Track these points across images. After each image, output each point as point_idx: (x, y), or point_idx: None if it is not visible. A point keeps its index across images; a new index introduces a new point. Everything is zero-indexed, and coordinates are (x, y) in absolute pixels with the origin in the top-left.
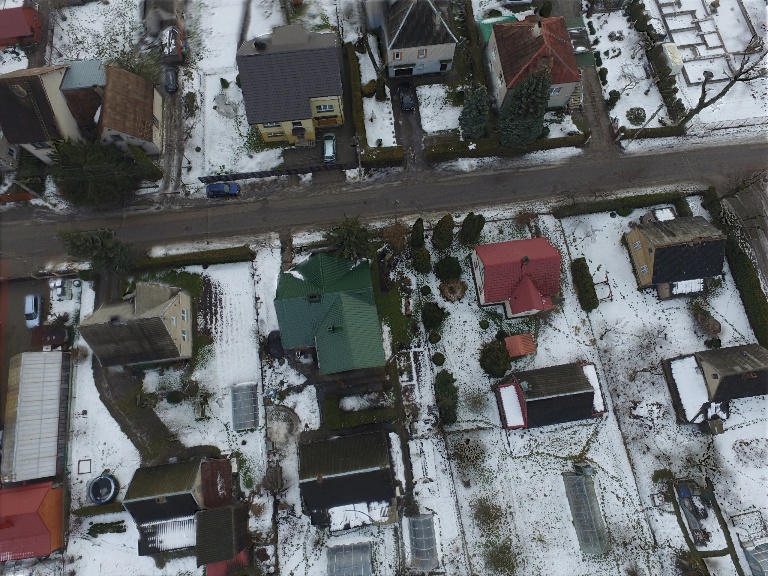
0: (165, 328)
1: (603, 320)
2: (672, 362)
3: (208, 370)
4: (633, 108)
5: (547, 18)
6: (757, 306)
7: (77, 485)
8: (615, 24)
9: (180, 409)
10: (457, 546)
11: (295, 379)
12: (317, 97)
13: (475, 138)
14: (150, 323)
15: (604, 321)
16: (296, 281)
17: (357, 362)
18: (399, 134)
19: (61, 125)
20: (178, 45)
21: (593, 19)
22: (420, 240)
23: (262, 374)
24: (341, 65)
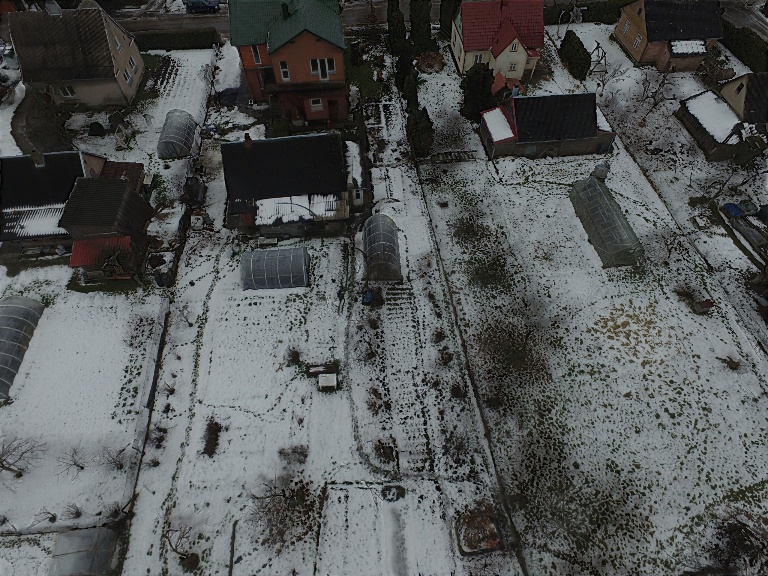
0: (104, 29)
1: None
2: (686, 102)
3: None
4: None
5: None
6: None
7: None
8: None
9: (100, 141)
10: None
11: (243, 120)
12: None
13: None
14: (88, 19)
15: None
16: None
17: (311, 26)
18: None
19: None
20: None
21: None
22: None
23: (206, 117)
24: None
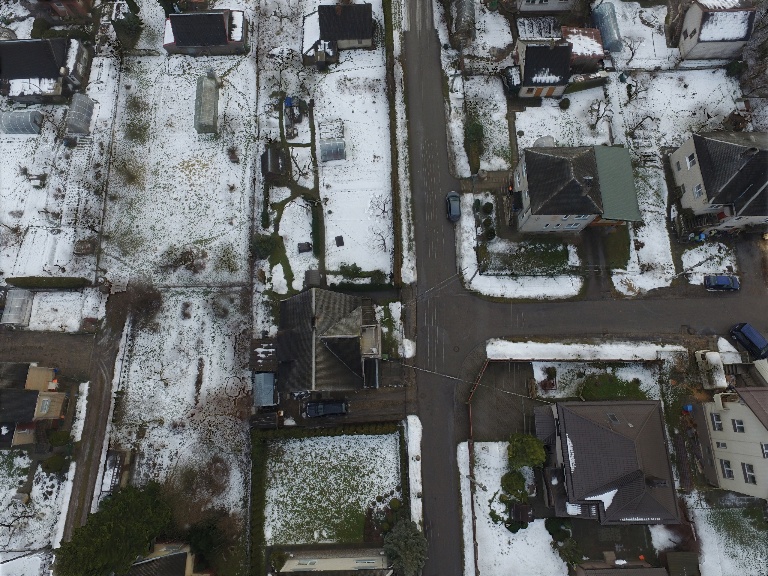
0: None
1: None
2: (305, 18)
3: None
4: None
5: None
6: None
7: None
8: None
9: None
10: (107, 123)
11: (21, 12)
12: None
13: None
14: None
15: None
16: None
17: None
18: None
19: None
20: None
21: None
22: None
23: None
24: None
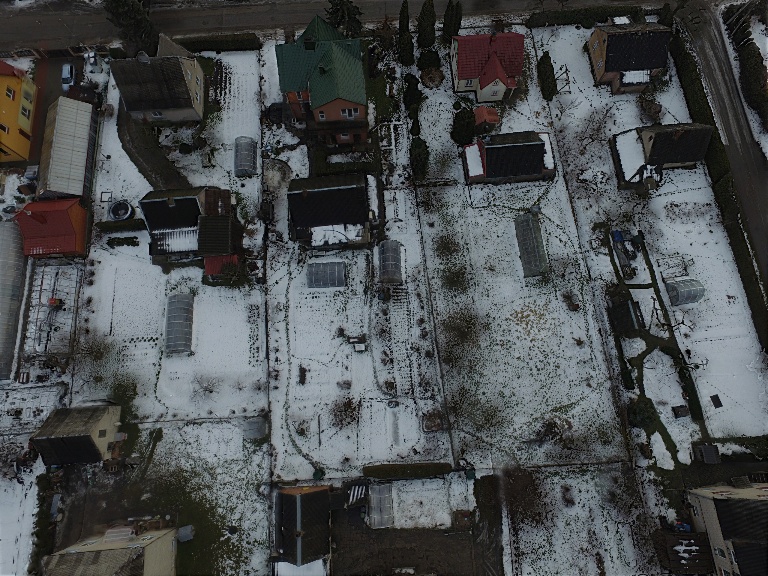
0: (182, 71)
1: None
2: (617, 136)
3: (216, 130)
4: None
5: None
6: (695, 95)
7: (99, 210)
8: None
9: (190, 158)
10: (419, 269)
11: (290, 139)
12: None
13: None
14: (170, 64)
15: None
16: None
17: (342, 93)
18: None
19: None
20: None
21: None
22: None
23: (262, 135)
24: None
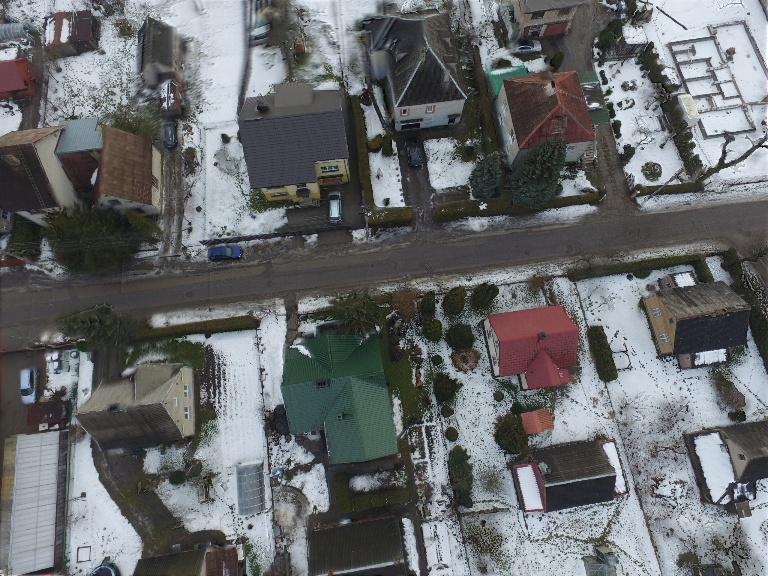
0: (167, 413)
1: (622, 391)
2: (695, 438)
3: (212, 448)
4: (648, 163)
5: (559, 73)
6: None
7: (76, 574)
8: (628, 73)
9: (183, 490)
10: None
11: (303, 457)
12: (322, 160)
13: (486, 197)
14: (151, 409)
15: (623, 392)
16: (303, 359)
17: (369, 453)
18: (407, 192)
19: (56, 192)
20: (177, 99)
21: (605, 68)
22: (431, 308)
23: (268, 452)
24: (346, 118)
